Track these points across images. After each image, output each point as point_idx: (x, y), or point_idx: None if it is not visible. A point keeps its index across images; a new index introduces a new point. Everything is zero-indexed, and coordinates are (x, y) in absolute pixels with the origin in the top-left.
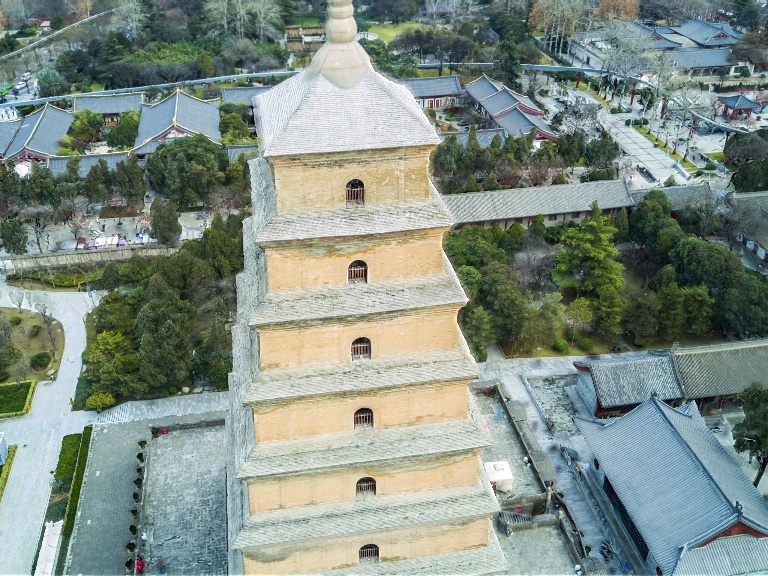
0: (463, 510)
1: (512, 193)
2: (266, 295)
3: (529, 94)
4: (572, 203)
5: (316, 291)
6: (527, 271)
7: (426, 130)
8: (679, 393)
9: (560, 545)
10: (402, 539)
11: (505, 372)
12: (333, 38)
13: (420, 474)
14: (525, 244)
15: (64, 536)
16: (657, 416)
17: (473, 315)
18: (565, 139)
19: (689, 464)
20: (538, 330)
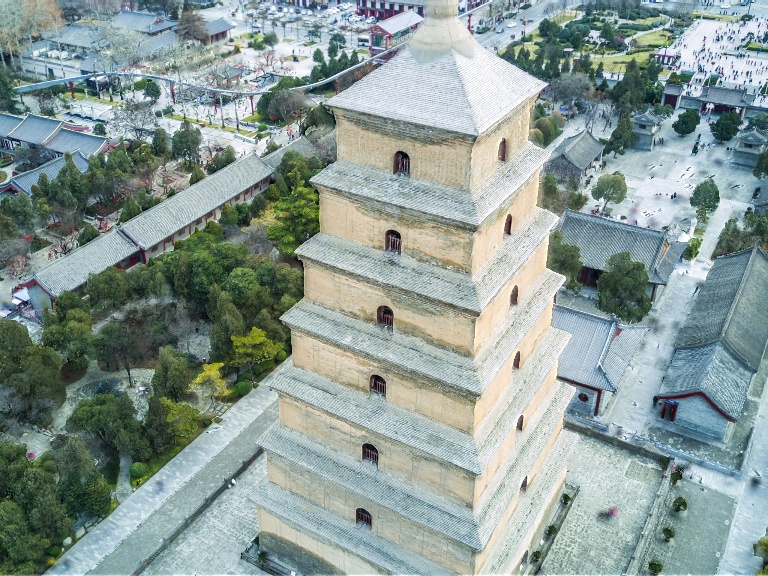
0: (563, 404)
1: (180, 198)
2: (472, 279)
3: (50, 114)
4: (231, 187)
5: (492, 258)
6: None
7: (530, 77)
8: None
9: None
10: None
11: None
12: (447, 12)
13: None
14: (230, 236)
15: None
16: None
17: (281, 306)
18: (140, 142)
19: (554, 313)
20: None
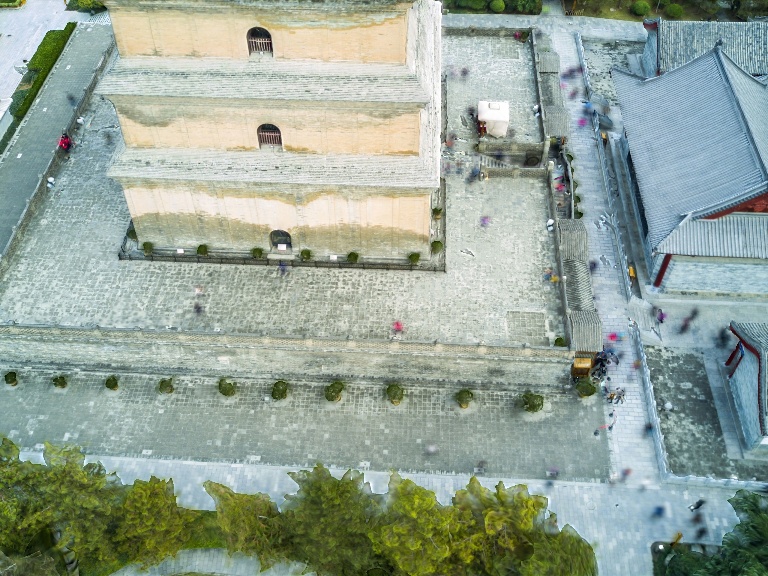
0: (381, 93)
1: None
2: None
3: None
4: None
5: None
6: None
7: None
8: (767, 69)
9: (540, 198)
10: (308, 124)
11: (558, 28)
12: None
13: (328, 35)
14: None
15: (16, 117)
16: (714, 70)
17: None
18: None
19: (731, 125)
20: None
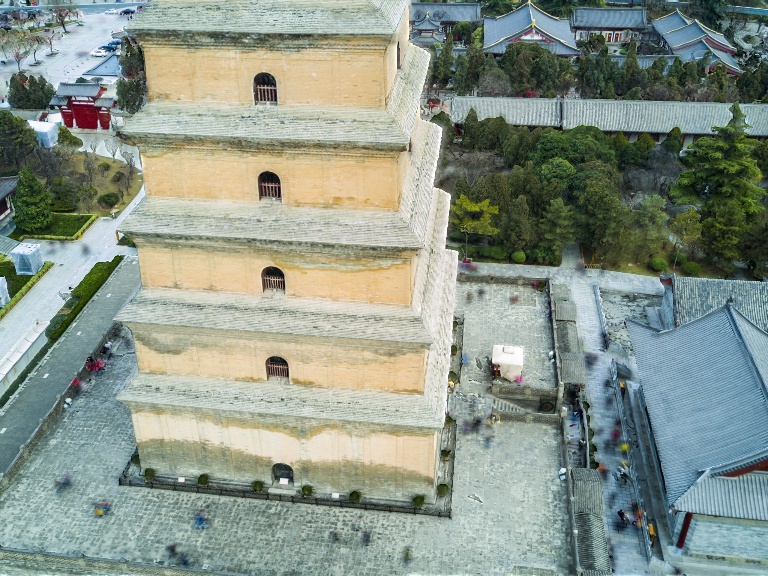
0: (386, 333)
1: (652, 105)
2: None
3: (726, 33)
4: (726, 125)
5: (211, 1)
6: (651, 193)
7: None
8: None
9: (553, 445)
10: (315, 359)
11: (577, 279)
12: None
13: (338, 276)
14: (651, 159)
15: (50, 339)
16: (726, 325)
17: (550, 208)
18: (750, 74)
19: (746, 380)
20: (629, 239)
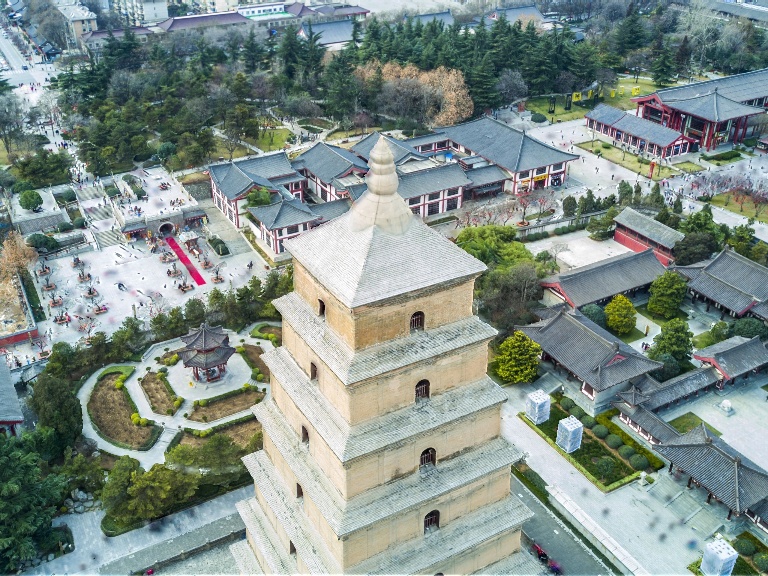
0: None
1: None
2: None
3: None
4: None
5: None
6: None
7: None
8: None
9: None
10: None
11: None
12: None
13: None
14: None
15: None
16: None
17: None
18: None
19: None
20: None
